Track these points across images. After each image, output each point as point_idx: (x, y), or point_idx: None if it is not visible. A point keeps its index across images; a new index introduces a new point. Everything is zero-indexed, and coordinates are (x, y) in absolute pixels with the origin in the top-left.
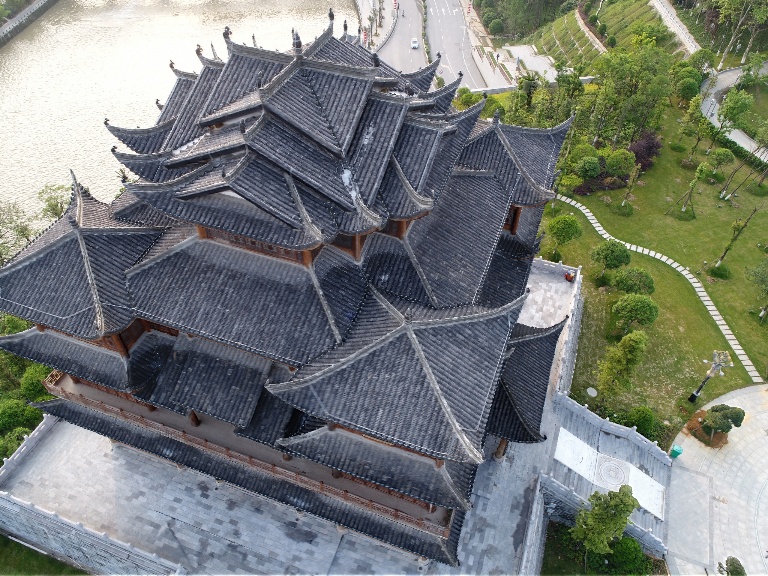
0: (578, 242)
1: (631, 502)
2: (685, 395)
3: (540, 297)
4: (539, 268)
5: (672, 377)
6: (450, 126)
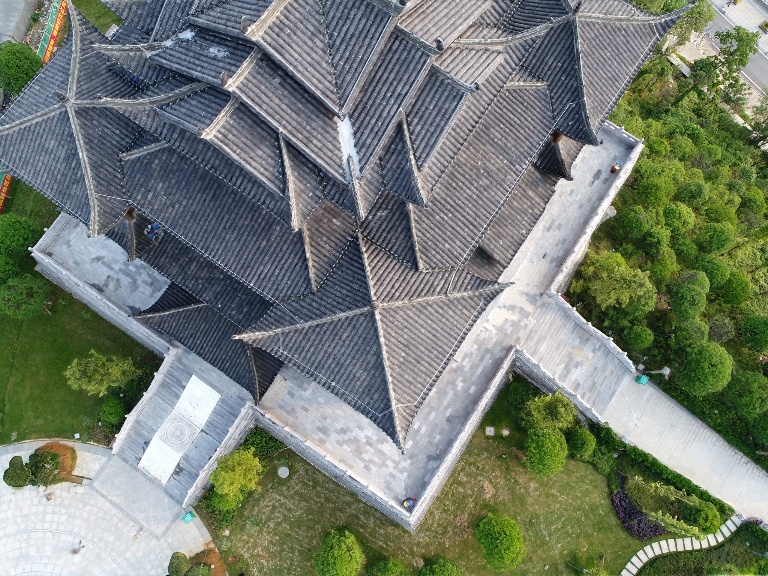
0: (509, 575)
1: (68, 375)
2: (250, 574)
3: (388, 451)
4: (435, 471)
5: (275, 574)
6: (254, 171)
